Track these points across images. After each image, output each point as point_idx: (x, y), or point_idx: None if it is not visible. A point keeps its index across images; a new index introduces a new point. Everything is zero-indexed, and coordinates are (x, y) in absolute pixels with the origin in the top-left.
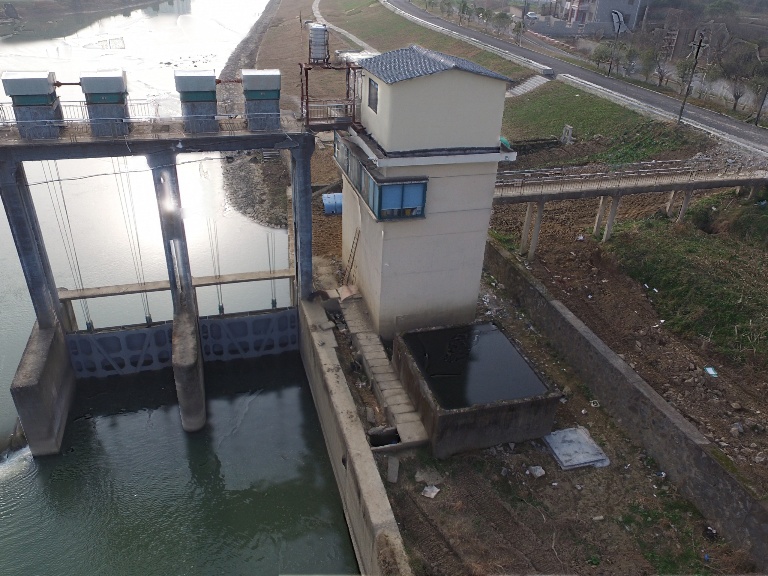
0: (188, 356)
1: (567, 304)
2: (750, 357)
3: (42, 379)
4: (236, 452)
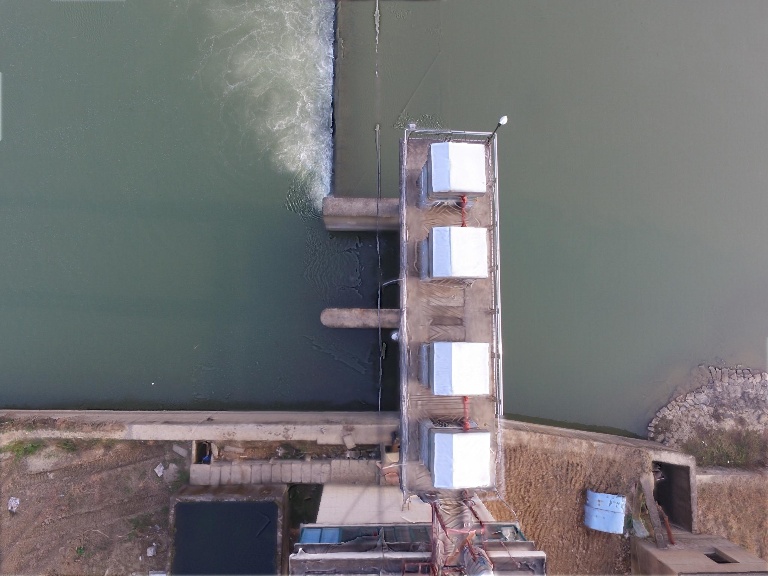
0: (332, 320)
1: None
2: None
3: (335, 216)
4: (288, 347)
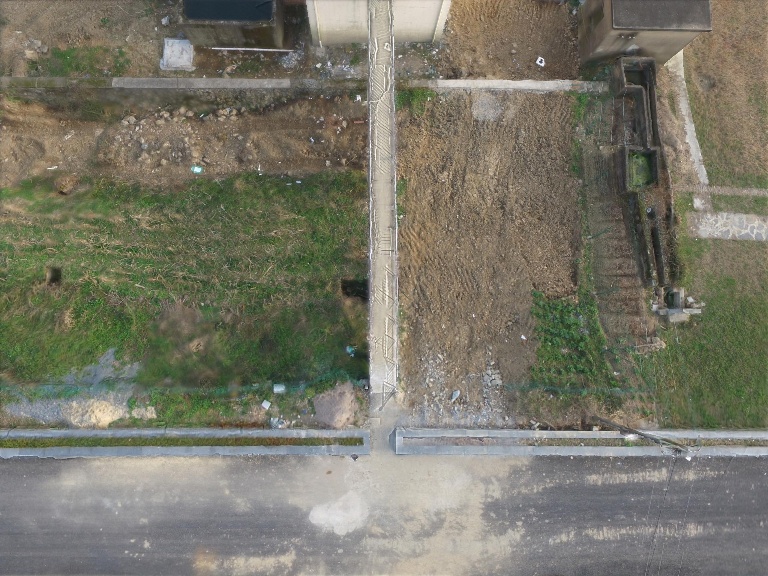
0: None
1: (296, 104)
2: (181, 185)
3: None
4: None
